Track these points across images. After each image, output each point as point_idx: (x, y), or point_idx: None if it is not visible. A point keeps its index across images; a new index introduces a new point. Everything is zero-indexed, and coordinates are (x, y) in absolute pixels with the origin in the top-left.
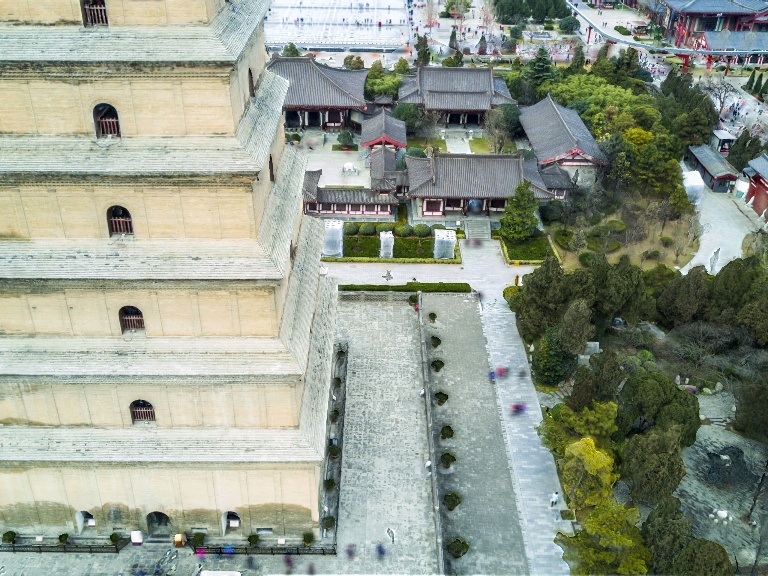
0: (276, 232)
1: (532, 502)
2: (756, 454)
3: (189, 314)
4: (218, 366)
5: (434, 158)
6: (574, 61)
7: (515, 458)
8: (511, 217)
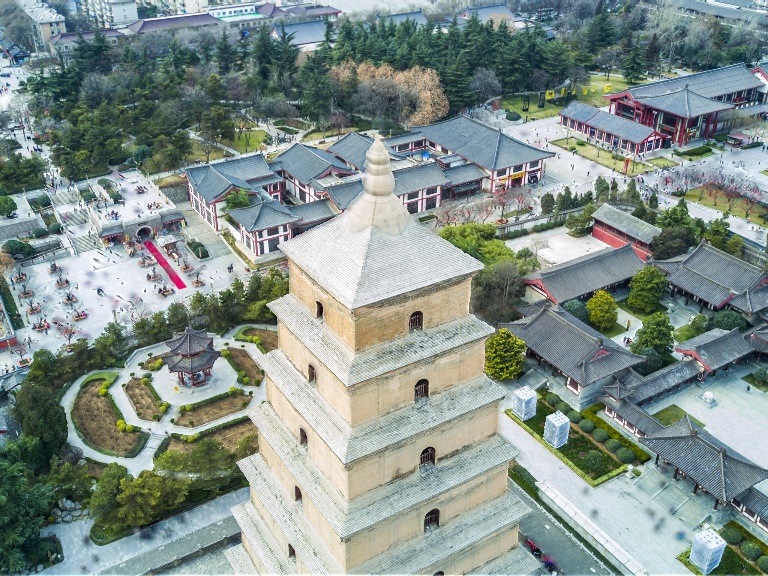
0: (379, 572)
1: None
2: None
3: None
4: None
5: None
6: None
7: None
8: None
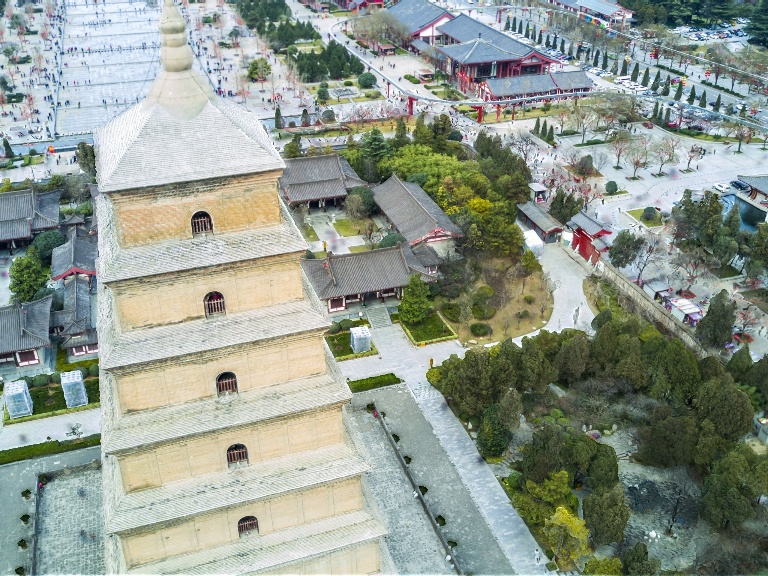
0: (346, 427)
1: (523, 563)
2: (657, 478)
3: (295, 510)
4: (323, 544)
5: (329, 261)
6: (398, 131)
7: (496, 529)
8: (409, 305)
